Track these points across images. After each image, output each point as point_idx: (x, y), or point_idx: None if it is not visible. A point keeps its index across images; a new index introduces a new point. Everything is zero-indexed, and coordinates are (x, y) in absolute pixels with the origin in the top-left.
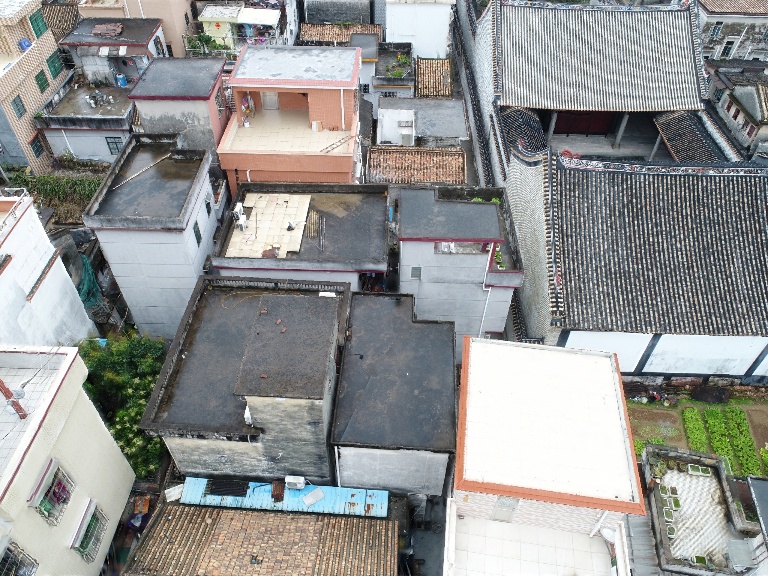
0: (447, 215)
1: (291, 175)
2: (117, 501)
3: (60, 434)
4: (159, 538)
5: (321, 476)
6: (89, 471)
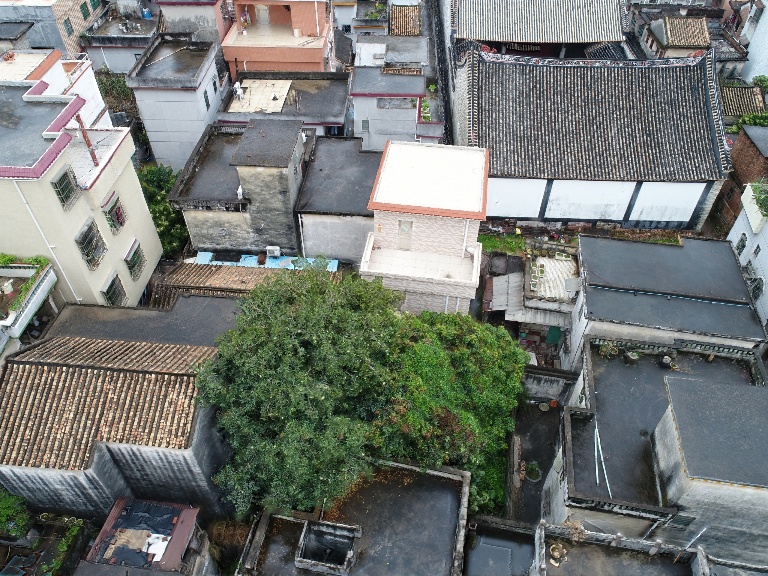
0: (387, 82)
1: (277, 66)
2: (151, 257)
3: (119, 180)
4: (180, 274)
5: (291, 248)
6: (135, 220)
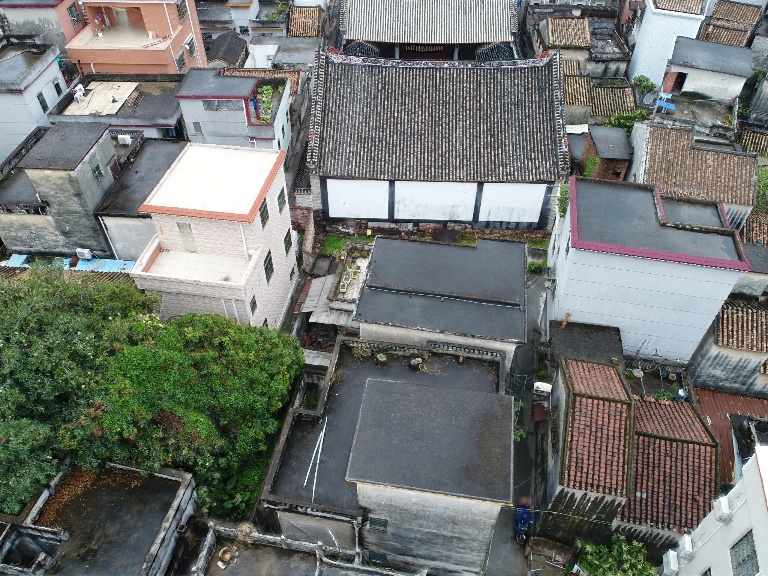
0: (217, 83)
1: (125, 68)
2: None
3: None
4: None
5: (103, 250)
6: None
